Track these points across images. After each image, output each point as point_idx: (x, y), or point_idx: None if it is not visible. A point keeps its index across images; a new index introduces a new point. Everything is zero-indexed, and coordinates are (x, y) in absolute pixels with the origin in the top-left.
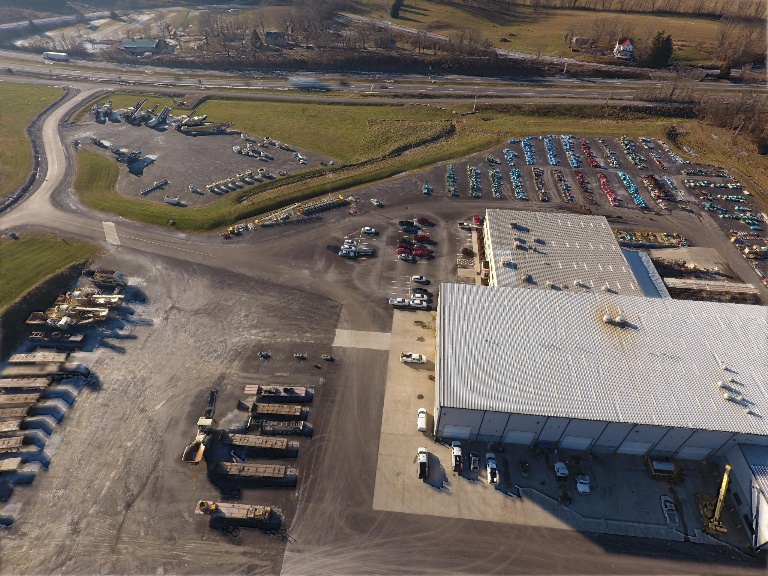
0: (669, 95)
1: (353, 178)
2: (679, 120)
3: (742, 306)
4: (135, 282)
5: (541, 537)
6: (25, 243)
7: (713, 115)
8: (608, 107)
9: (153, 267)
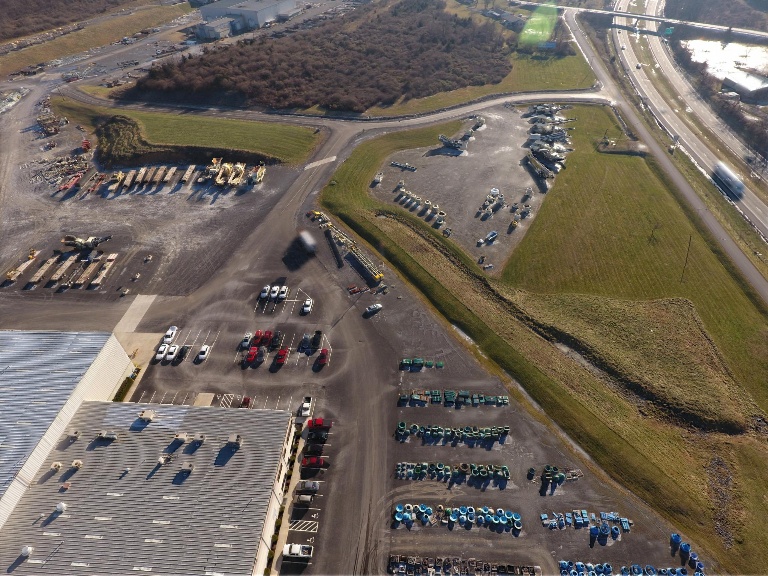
0: None
1: (434, 284)
2: None
3: None
4: (257, 187)
5: None
6: (309, 137)
7: None
8: None
9: (273, 190)
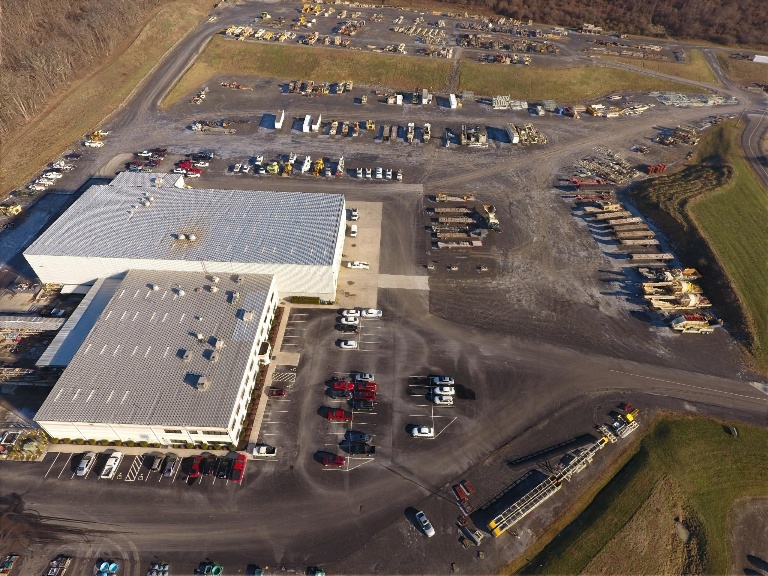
0: None
1: None
2: None
3: (50, 253)
4: (664, 331)
5: None
6: None
7: None
8: None
9: (667, 351)
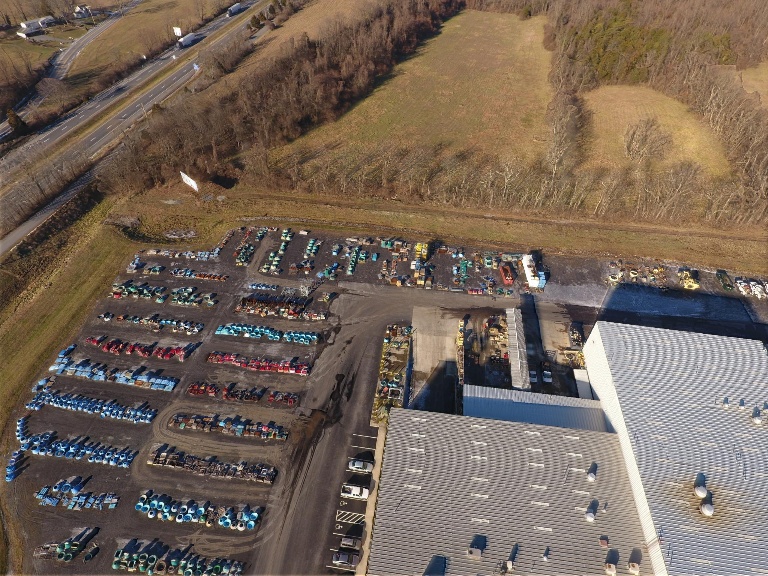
0: (39, 193)
1: None
2: (99, 211)
3: (607, 343)
4: None
5: None
6: None
7: (131, 183)
8: (2, 268)
9: None
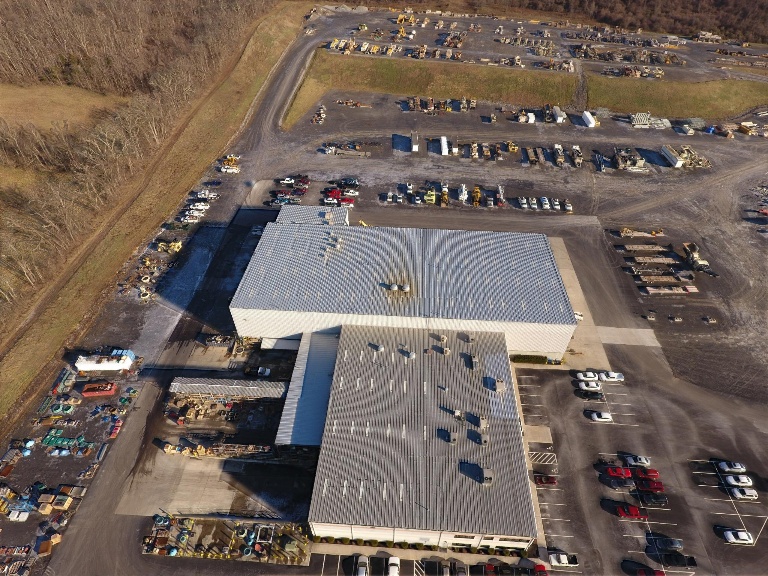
0: None
1: None
2: None
3: (258, 306)
4: None
5: None
6: None
7: None
8: None
9: None
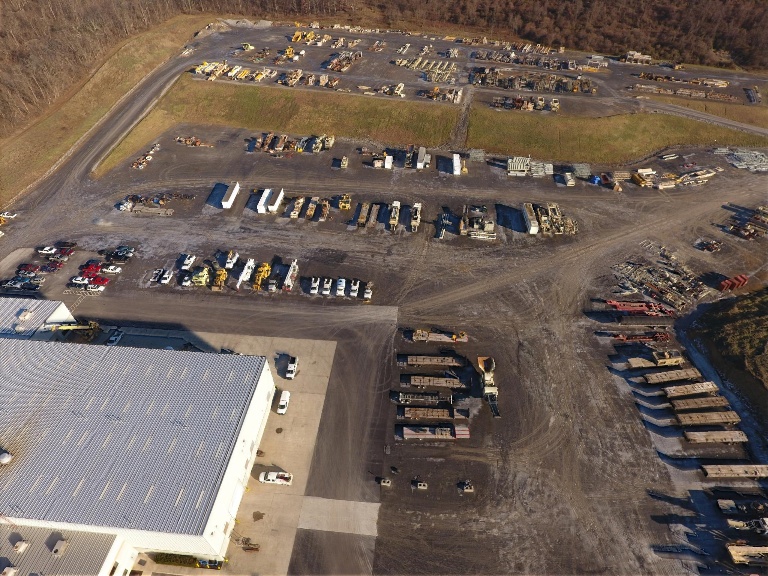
0: None
1: None
2: None
3: None
4: None
5: (220, 328)
6: None
7: None
8: None
9: None
